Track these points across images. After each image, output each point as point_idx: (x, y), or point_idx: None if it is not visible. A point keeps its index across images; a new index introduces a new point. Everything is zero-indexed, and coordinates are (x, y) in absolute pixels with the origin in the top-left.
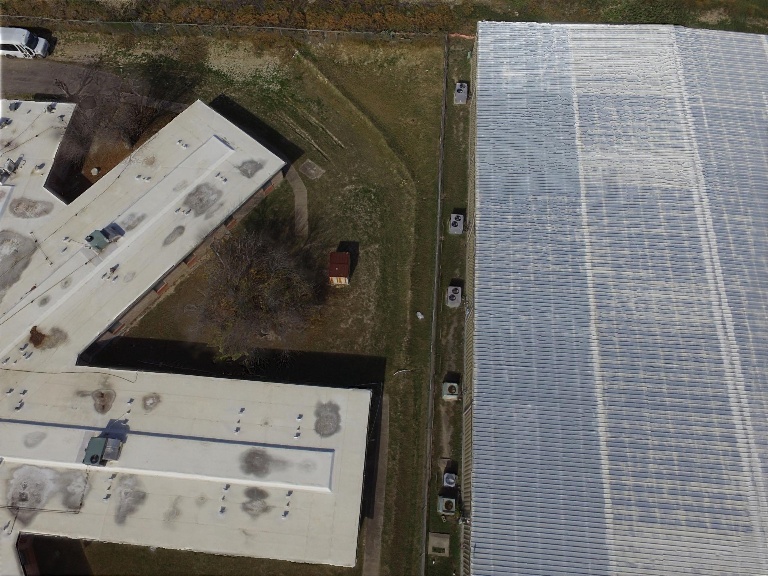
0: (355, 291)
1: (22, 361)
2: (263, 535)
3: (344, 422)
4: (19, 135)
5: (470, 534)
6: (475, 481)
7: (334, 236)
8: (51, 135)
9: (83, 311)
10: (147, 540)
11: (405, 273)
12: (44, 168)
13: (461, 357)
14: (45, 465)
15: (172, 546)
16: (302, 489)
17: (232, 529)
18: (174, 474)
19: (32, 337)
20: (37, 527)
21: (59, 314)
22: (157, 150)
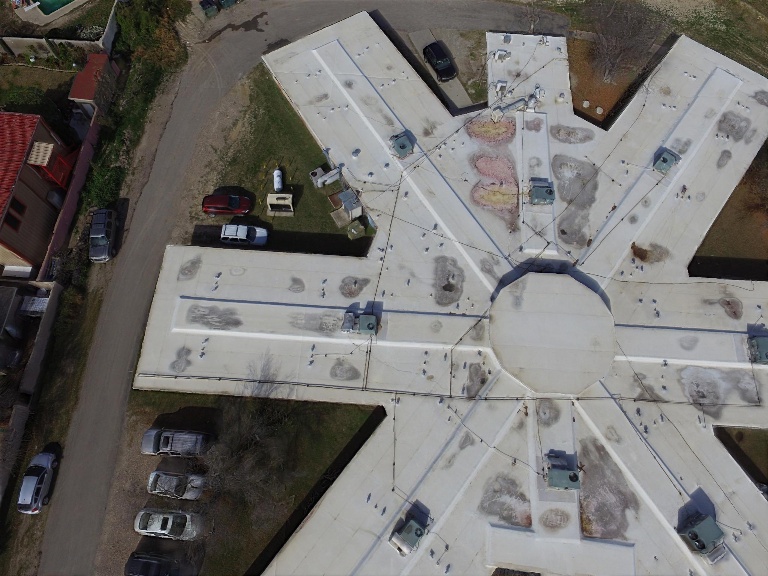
0: None
1: (637, 274)
2: None
3: None
4: (525, 66)
5: None
6: None
7: None
8: (557, 66)
9: (672, 228)
10: None
11: None
12: (566, 97)
13: None
14: (709, 365)
15: None
16: None
17: None
18: None
19: (635, 252)
20: (728, 420)
21: (651, 231)
22: (668, 81)
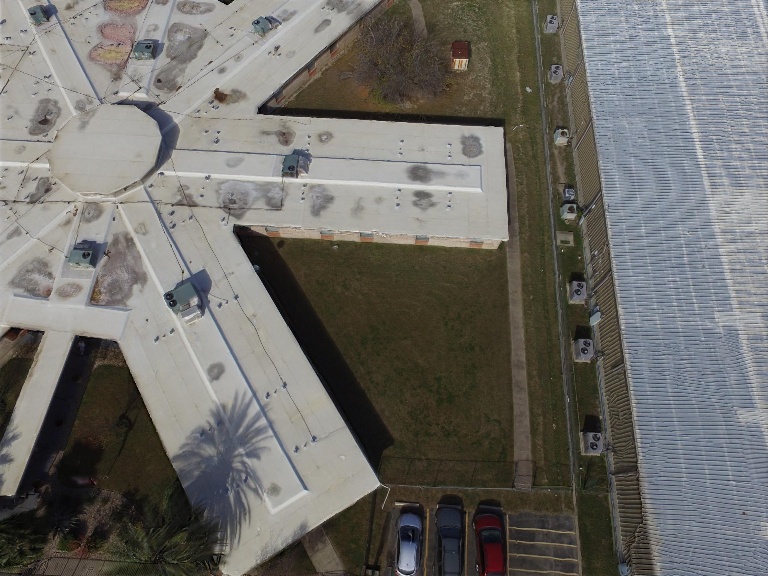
0: (472, 75)
1: (212, 112)
2: (433, 221)
3: (485, 148)
4: None
5: (603, 200)
6: (602, 166)
7: (449, 37)
8: None
9: (256, 78)
10: (340, 226)
11: (512, 61)
12: None
13: (566, 116)
14: (246, 180)
15: (362, 229)
16: (460, 190)
17: (408, 217)
18: (355, 182)
19: (216, 96)
20: (248, 220)
21: (236, 80)
22: None
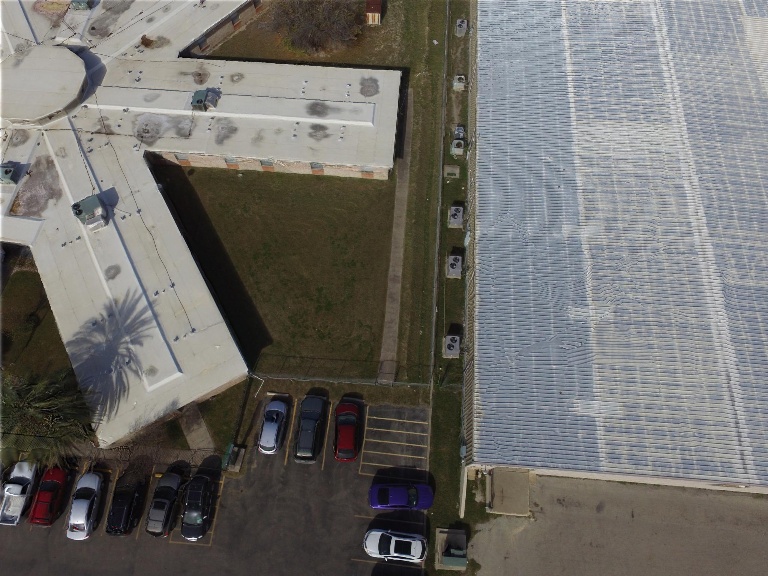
0: (385, 29)
1: (137, 55)
2: (325, 150)
3: (382, 89)
4: None
5: None
6: (479, 101)
7: None
8: None
9: (181, 26)
10: (240, 153)
11: (423, 17)
12: None
13: (467, 65)
14: (161, 112)
15: (259, 156)
16: (353, 124)
17: (302, 146)
18: (258, 115)
19: (143, 41)
20: (158, 147)
21: (162, 28)
22: None
